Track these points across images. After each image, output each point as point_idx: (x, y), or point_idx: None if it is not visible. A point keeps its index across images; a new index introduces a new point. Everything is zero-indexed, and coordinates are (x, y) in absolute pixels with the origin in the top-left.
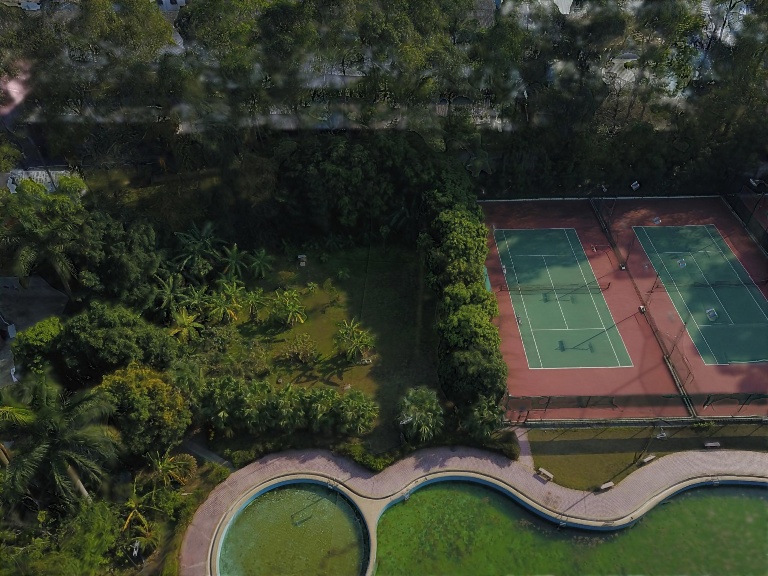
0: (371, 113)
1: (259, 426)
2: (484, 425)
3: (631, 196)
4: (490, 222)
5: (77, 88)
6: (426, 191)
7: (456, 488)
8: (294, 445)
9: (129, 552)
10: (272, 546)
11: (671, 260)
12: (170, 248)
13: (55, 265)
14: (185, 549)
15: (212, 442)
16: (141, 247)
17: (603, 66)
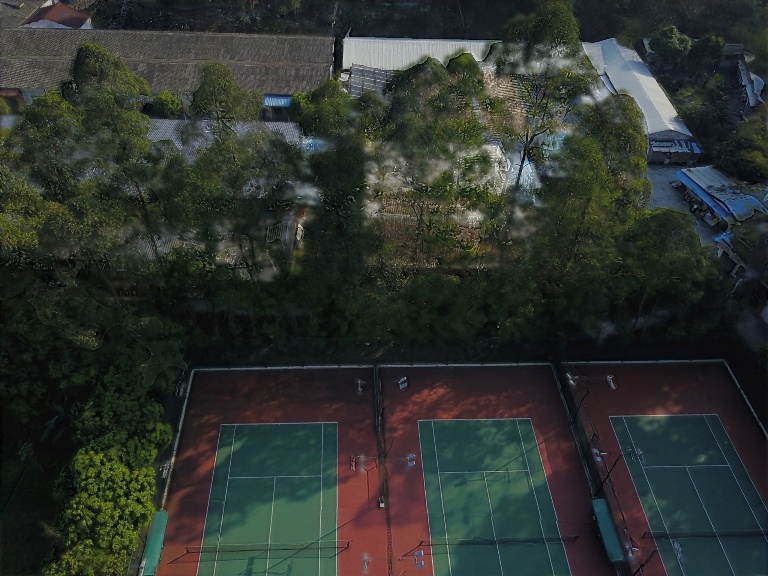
0: None
1: None
2: None
3: (432, 362)
4: (223, 410)
5: None
6: (79, 402)
7: None
8: None
9: None
10: None
11: (454, 489)
12: None
13: None
14: None
15: None
16: None
17: (369, 203)
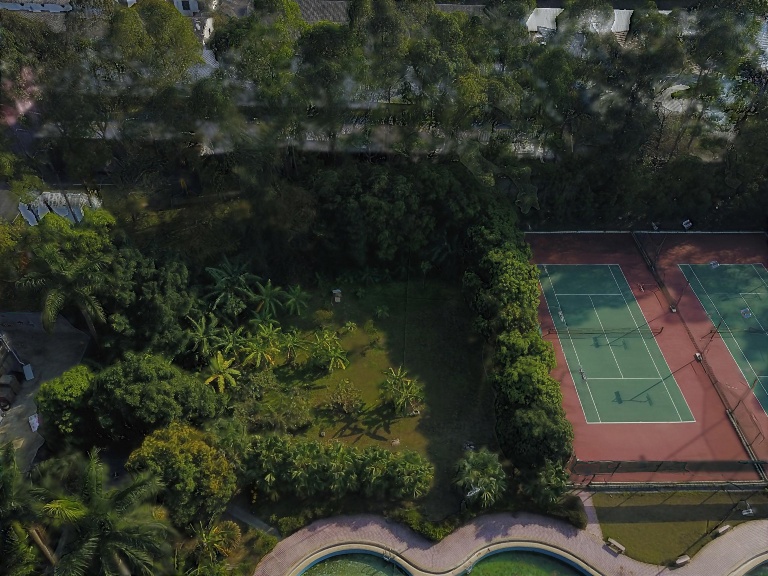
0: (417, 144)
1: (307, 490)
2: (549, 490)
3: (674, 230)
4: None
5: (102, 110)
6: (472, 227)
7: (520, 560)
8: (345, 510)
9: None
10: None
11: (722, 302)
12: (201, 284)
13: (81, 306)
14: None
15: (255, 506)
16: (173, 286)
17: None
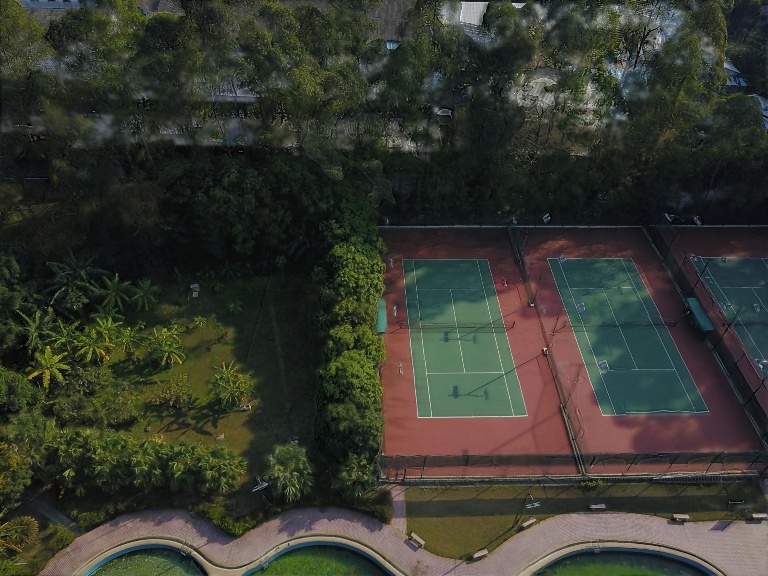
0: (264, 137)
1: (111, 485)
2: (356, 485)
3: (551, 225)
4: (401, 251)
5: None
6: (324, 221)
7: (321, 554)
8: (149, 505)
9: None
10: None
11: (582, 297)
12: (42, 279)
13: None
14: None
15: (61, 501)
16: (1, 280)
17: None
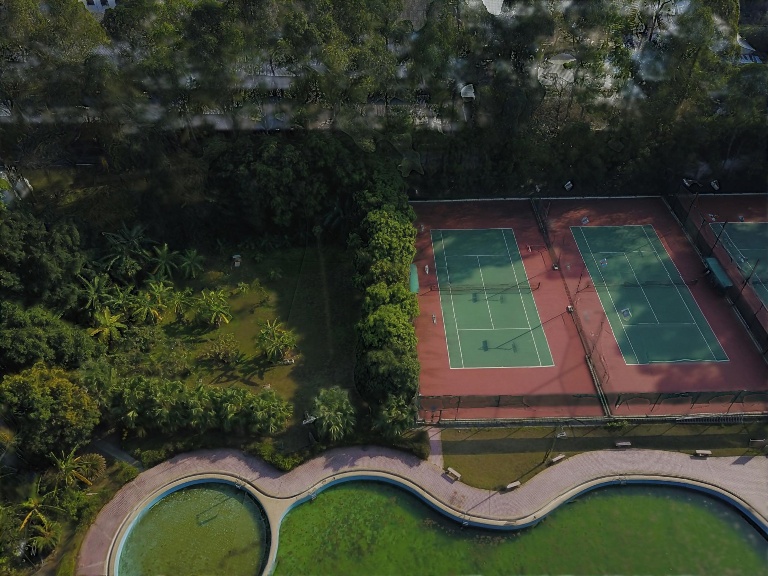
0: (300, 113)
1: (170, 426)
2: (395, 425)
3: (572, 196)
4: (429, 222)
5: (5, 88)
6: (357, 191)
7: (365, 488)
8: (205, 445)
9: (27, 552)
10: (174, 546)
11: None
12: (98, 248)
13: None
14: (85, 549)
15: (124, 442)
16: (64, 247)
17: (538, 66)
